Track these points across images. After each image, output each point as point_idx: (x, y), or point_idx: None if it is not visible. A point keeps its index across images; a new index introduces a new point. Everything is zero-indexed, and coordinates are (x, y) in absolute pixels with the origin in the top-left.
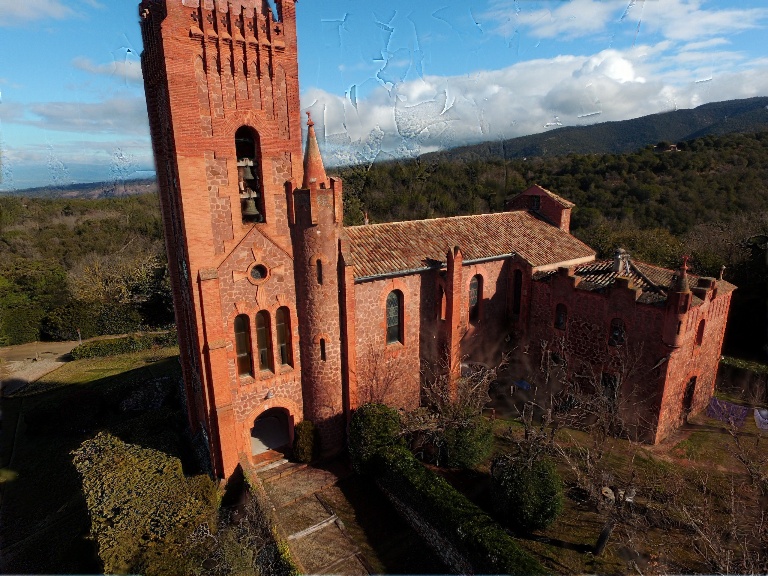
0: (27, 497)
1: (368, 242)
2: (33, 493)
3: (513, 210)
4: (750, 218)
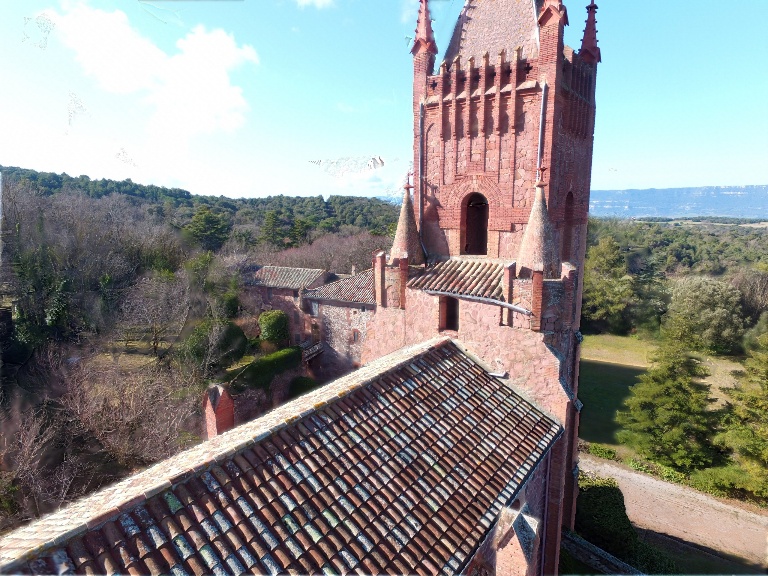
0: (723, 568)
1: (371, 372)
2: (726, 573)
3: None
4: None
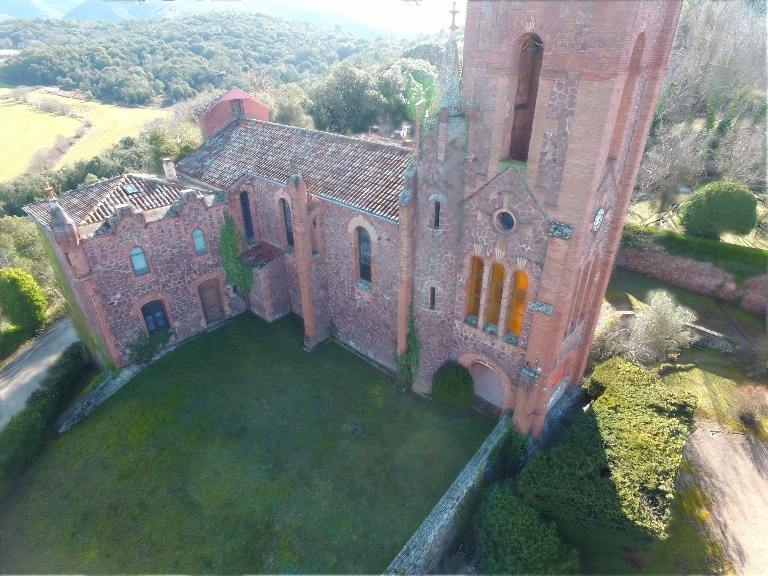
0: None
1: None
2: None
3: (214, 122)
4: (188, 104)
